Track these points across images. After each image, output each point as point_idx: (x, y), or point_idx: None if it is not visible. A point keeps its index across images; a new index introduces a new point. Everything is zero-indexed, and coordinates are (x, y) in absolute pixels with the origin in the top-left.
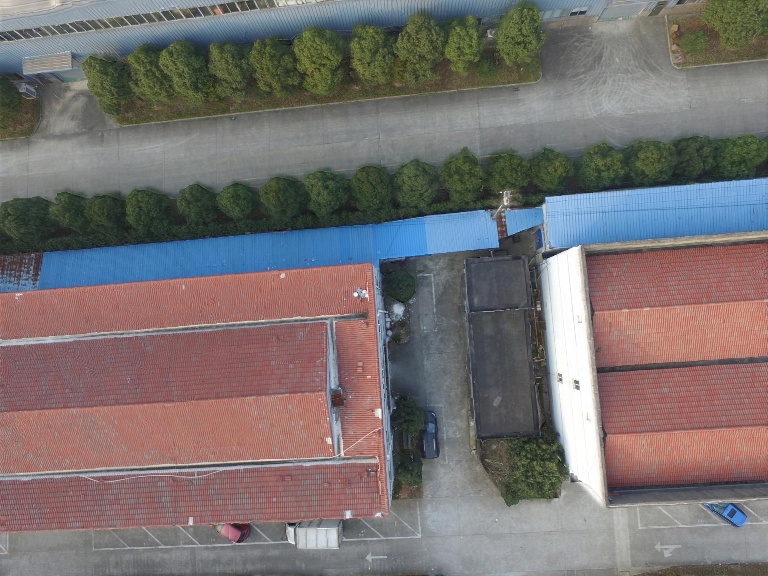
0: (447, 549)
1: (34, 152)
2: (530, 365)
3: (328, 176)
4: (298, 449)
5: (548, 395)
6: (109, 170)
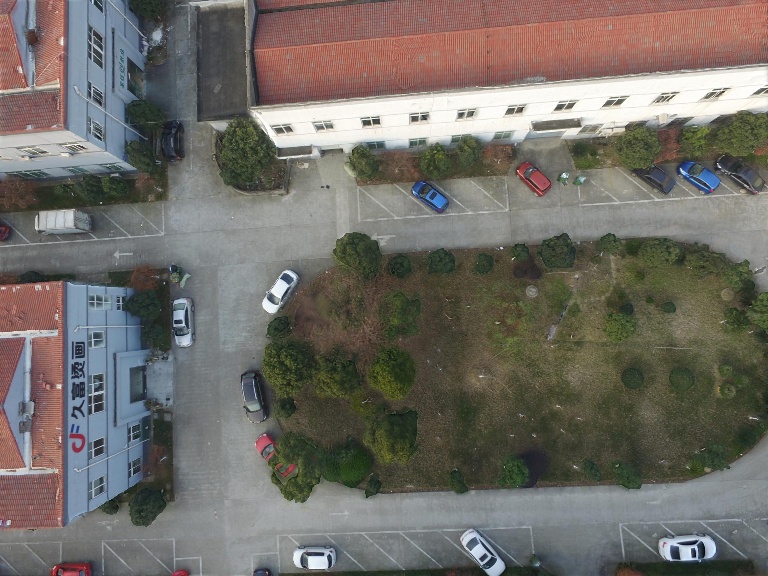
0: (187, 245)
1: None
2: None
3: None
4: None
5: None
6: None
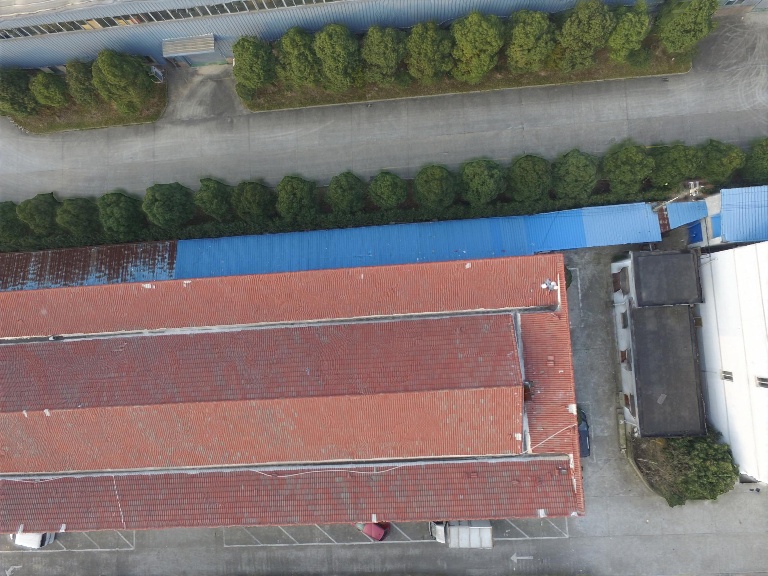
0: (596, 550)
1: (160, 138)
2: (695, 362)
3: (491, 165)
4: (484, 445)
5: (701, 393)
6: (239, 157)
